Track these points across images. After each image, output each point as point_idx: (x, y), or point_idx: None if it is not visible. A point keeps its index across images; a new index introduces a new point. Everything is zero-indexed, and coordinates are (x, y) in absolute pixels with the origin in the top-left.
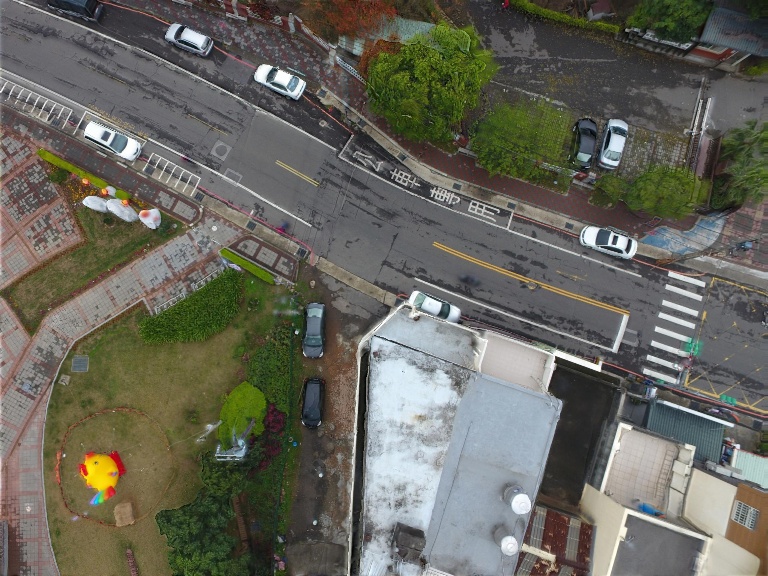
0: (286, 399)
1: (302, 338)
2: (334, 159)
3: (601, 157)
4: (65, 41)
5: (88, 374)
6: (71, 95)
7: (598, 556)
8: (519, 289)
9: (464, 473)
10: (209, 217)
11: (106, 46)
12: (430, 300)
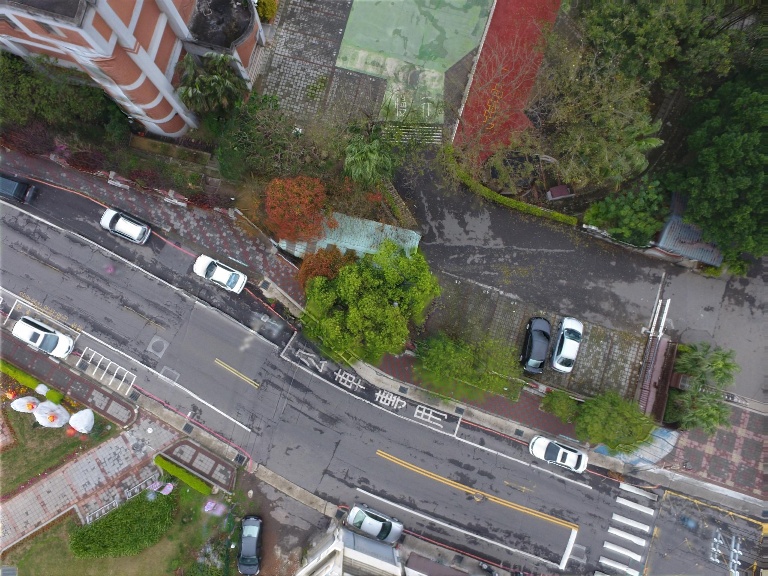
0: None
1: (237, 557)
2: (276, 359)
3: (553, 362)
4: None
5: None
6: (1, 282)
7: None
8: (465, 500)
9: None
10: (144, 418)
11: (39, 229)
12: (370, 520)
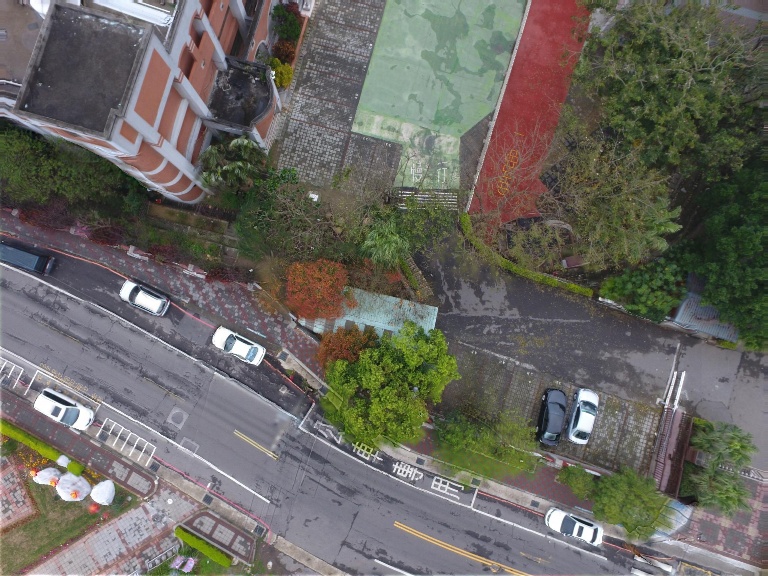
0: None
1: None
2: (294, 430)
3: (569, 435)
4: (16, 293)
5: None
6: (22, 352)
7: None
8: (481, 572)
9: None
10: (164, 489)
11: (58, 300)
12: None
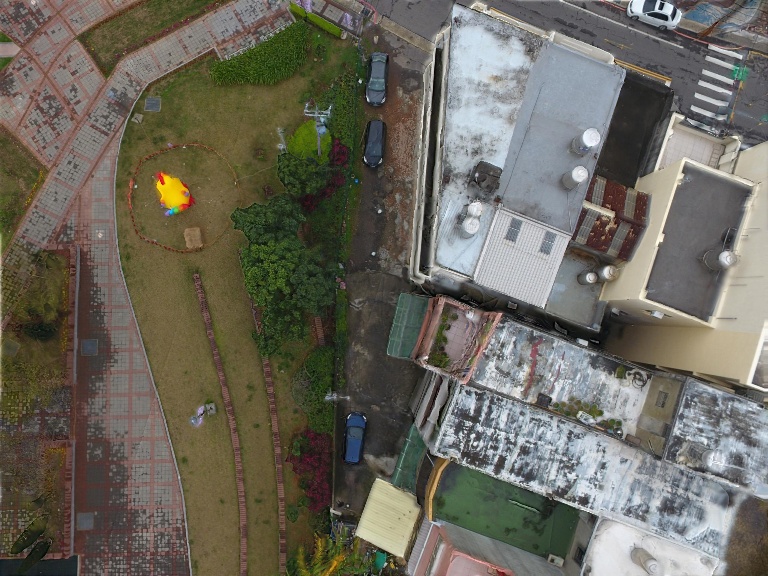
0: (351, 134)
1: (366, 82)
2: None
3: None
4: None
5: (160, 114)
6: None
7: (655, 209)
8: None
9: (535, 128)
10: None
11: None
12: None
